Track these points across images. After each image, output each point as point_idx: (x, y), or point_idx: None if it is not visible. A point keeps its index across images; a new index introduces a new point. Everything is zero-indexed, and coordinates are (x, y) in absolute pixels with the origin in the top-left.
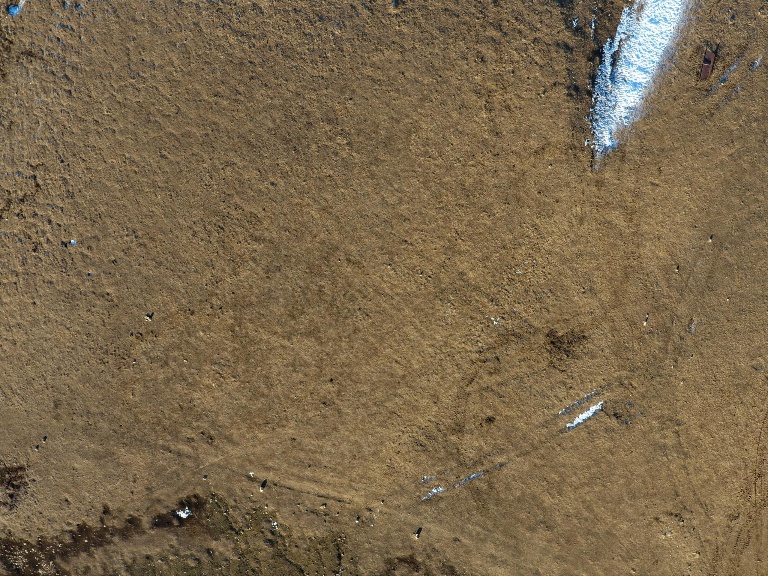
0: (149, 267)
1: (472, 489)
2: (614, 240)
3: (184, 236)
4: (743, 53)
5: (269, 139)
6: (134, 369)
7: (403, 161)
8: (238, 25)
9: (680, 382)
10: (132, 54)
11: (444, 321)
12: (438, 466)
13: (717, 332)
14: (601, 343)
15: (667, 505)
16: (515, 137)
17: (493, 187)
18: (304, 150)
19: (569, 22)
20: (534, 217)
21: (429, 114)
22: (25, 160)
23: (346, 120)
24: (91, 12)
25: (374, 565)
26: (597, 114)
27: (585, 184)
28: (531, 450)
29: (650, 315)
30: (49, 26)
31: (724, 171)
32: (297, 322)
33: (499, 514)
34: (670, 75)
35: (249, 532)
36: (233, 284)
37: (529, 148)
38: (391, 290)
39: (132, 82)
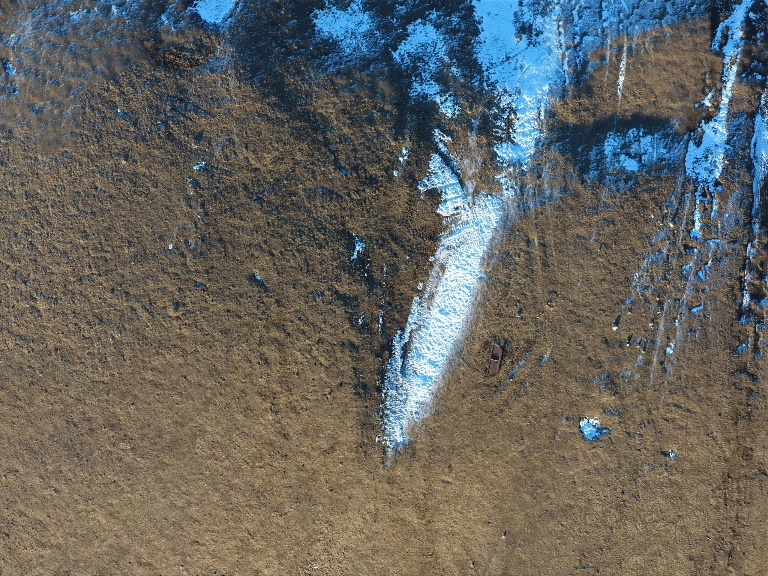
0: None
1: None
2: (408, 537)
3: None
4: (531, 347)
5: (51, 446)
6: None
7: (189, 464)
8: (16, 329)
9: None
10: None
11: None
12: None
13: None
14: None
15: None
16: (303, 438)
17: (283, 487)
18: (87, 457)
19: (354, 320)
20: (327, 514)
21: (214, 417)
22: None
23: (129, 425)
24: None
25: None
26: (388, 409)
27: (377, 481)
28: None
29: None
30: None
31: (515, 468)
32: None
33: None
34: (459, 371)
35: None
36: None
37: (318, 448)
38: None
39: None
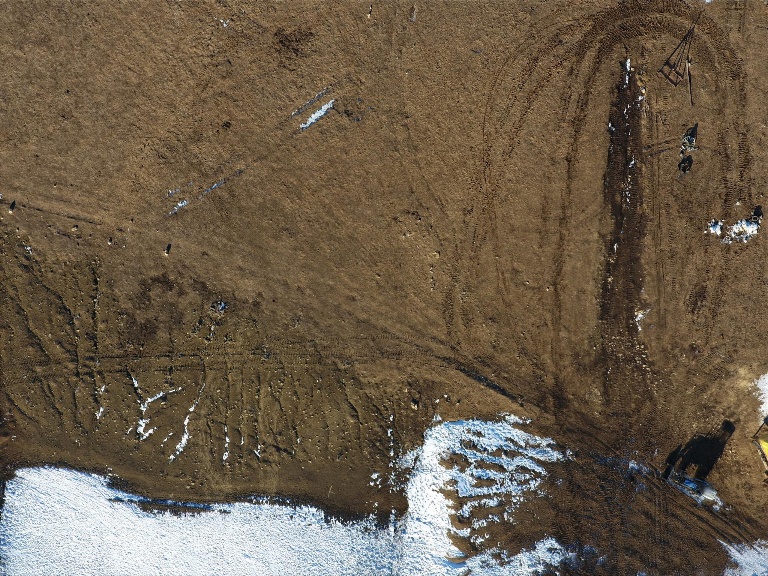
0: None
1: (214, 199)
2: None
3: None
4: None
5: None
6: None
7: None
8: None
9: (405, 73)
10: None
11: (173, 24)
12: (181, 178)
13: (437, 18)
14: (328, 39)
15: (403, 203)
16: None
17: None
18: None
19: None
20: None
21: None
22: None
23: None
24: None
25: (129, 287)
26: None
27: None
28: (268, 154)
29: (374, 7)
30: None
31: None
32: (27, 30)
33: (242, 223)
34: None
35: (3, 257)
36: None
37: None
38: None
39: None
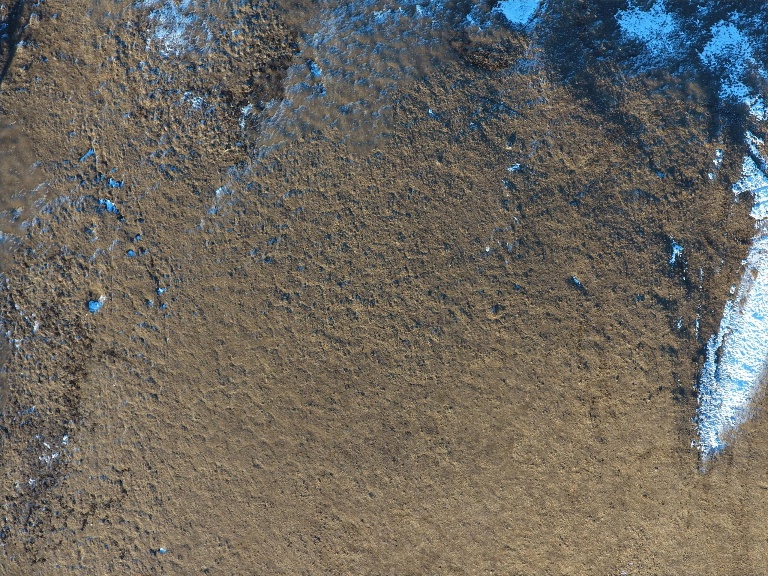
0: None
1: None
2: (722, 543)
3: (279, 546)
4: None
5: (367, 449)
6: None
7: (505, 469)
8: (332, 331)
9: None
10: (221, 359)
11: None
12: None
13: None
14: None
15: None
16: (620, 443)
17: (598, 492)
18: (403, 460)
19: (674, 324)
20: (639, 519)
21: (532, 422)
22: (110, 464)
23: (446, 429)
24: (176, 313)
25: None
26: (702, 414)
27: (692, 486)
28: None
29: None
30: (132, 326)
31: None
32: None
33: None
34: None
35: None
36: None
37: (634, 453)
38: None
39: (222, 388)
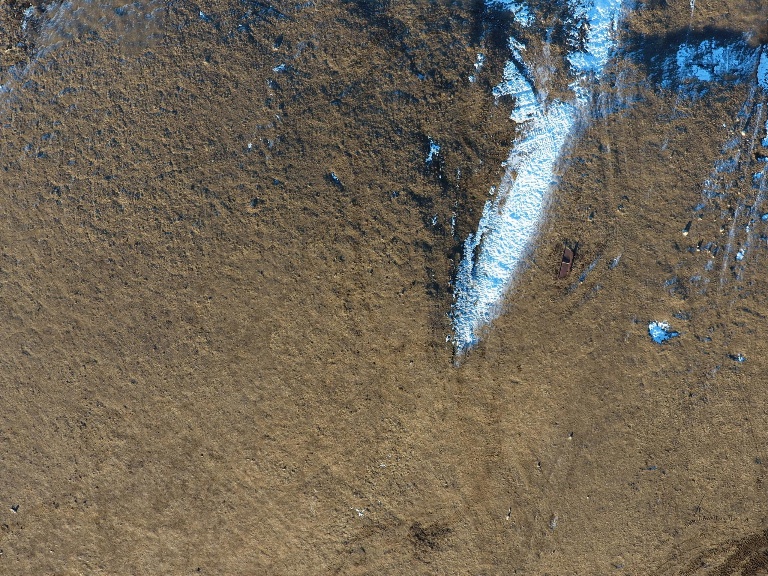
0: (13, 461)
1: None
2: (475, 436)
3: (47, 431)
4: (602, 251)
5: (129, 337)
6: (1, 560)
7: (263, 359)
8: (98, 223)
9: None
10: None
11: (309, 513)
12: None
13: (578, 529)
14: (465, 536)
15: None
16: (375, 335)
17: (354, 384)
18: (164, 348)
19: (428, 220)
20: (396, 412)
21: (288, 313)
22: None
23: (206, 319)
24: None
25: None
26: (458, 310)
27: (446, 380)
28: None
29: (513, 510)
30: None
31: (583, 369)
32: (162, 515)
33: None
34: (530, 273)
35: None
36: (97, 479)
37: (389, 346)
38: (255, 483)
39: None
